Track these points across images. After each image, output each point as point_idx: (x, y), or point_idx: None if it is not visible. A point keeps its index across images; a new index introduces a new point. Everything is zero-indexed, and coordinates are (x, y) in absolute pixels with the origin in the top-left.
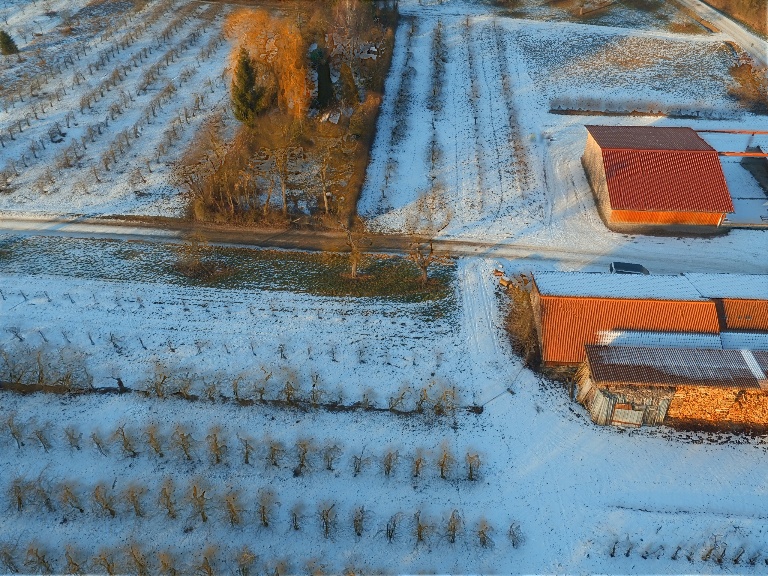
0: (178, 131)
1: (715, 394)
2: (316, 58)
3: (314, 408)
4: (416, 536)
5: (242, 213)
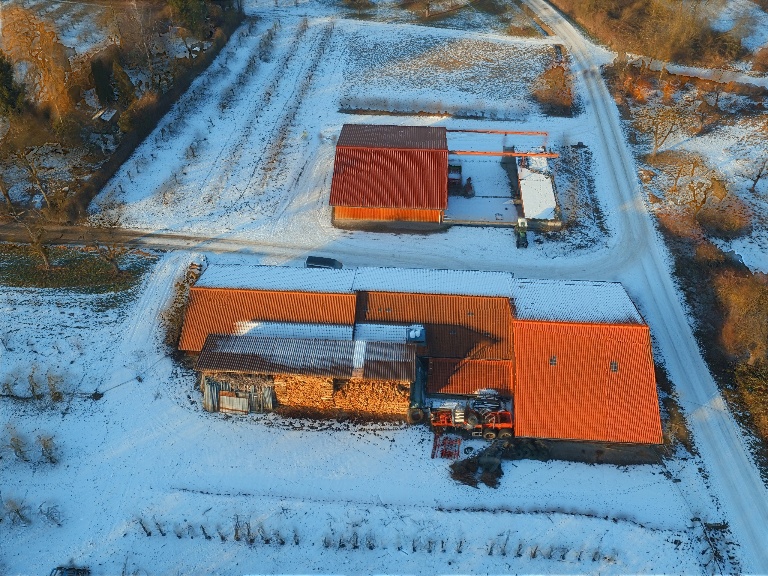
0: None
1: (312, 382)
2: (134, 57)
3: None
4: None
5: None
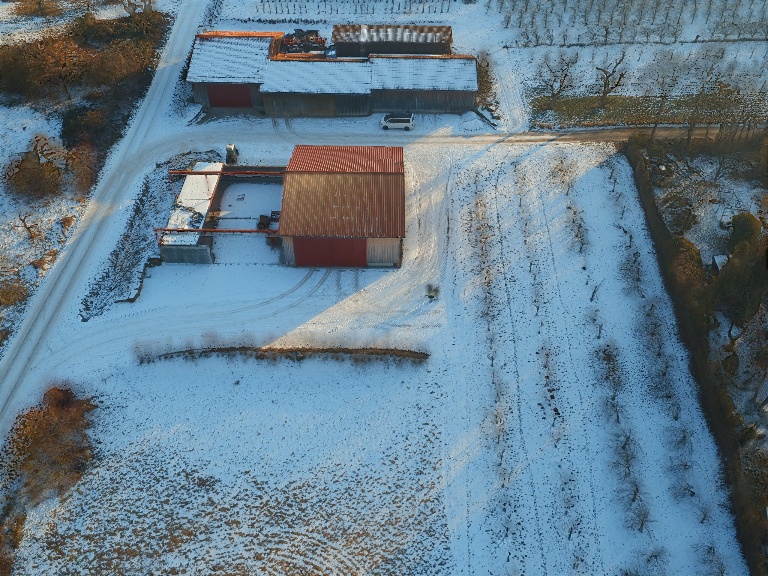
0: None
1: None
2: None
3: (591, 43)
4: None
5: None
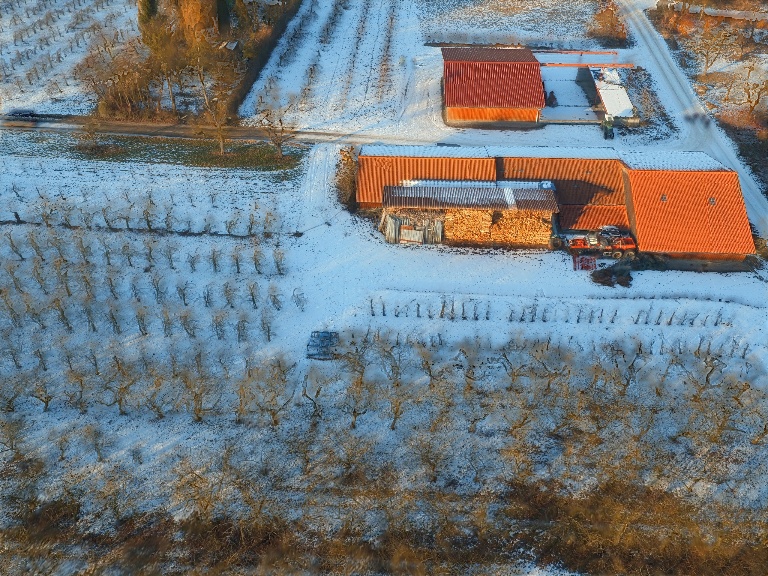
0: (97, 57)
1: (476, 216)
2: (230, 5)
3: (170, 234)
4: (227, 302)
5: (138, 111)
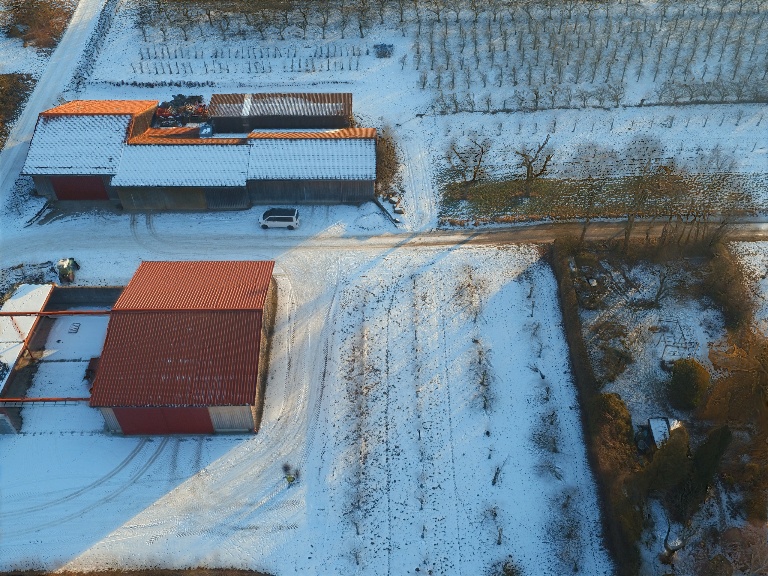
0: None
1: None
2: None
3: (519, 109)
4: None
5: None
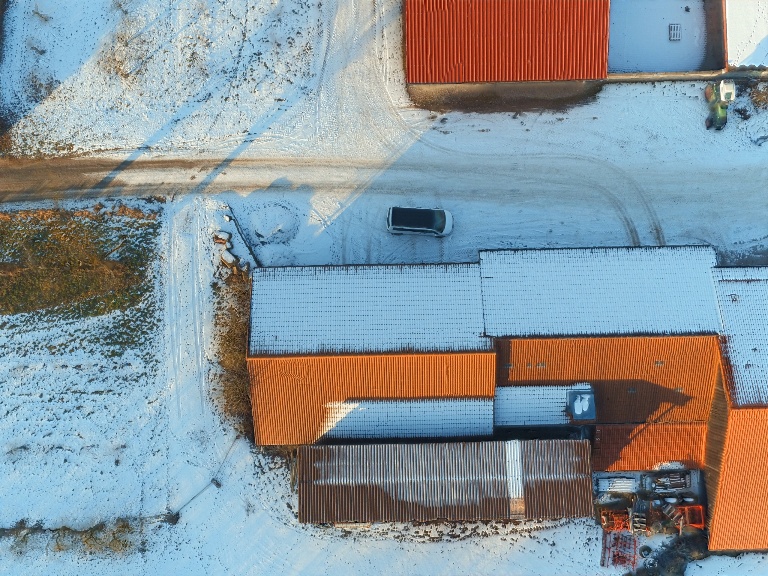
0: None
1: None
2: None
3: None
4: None
5: None
